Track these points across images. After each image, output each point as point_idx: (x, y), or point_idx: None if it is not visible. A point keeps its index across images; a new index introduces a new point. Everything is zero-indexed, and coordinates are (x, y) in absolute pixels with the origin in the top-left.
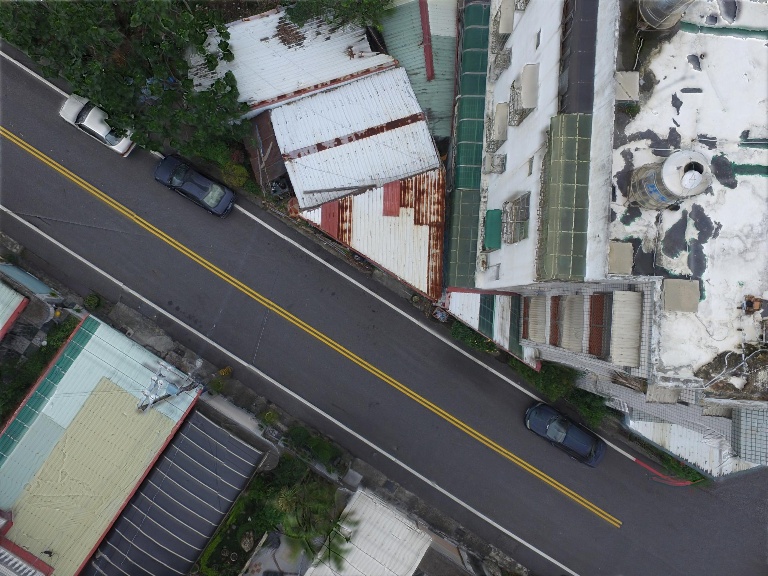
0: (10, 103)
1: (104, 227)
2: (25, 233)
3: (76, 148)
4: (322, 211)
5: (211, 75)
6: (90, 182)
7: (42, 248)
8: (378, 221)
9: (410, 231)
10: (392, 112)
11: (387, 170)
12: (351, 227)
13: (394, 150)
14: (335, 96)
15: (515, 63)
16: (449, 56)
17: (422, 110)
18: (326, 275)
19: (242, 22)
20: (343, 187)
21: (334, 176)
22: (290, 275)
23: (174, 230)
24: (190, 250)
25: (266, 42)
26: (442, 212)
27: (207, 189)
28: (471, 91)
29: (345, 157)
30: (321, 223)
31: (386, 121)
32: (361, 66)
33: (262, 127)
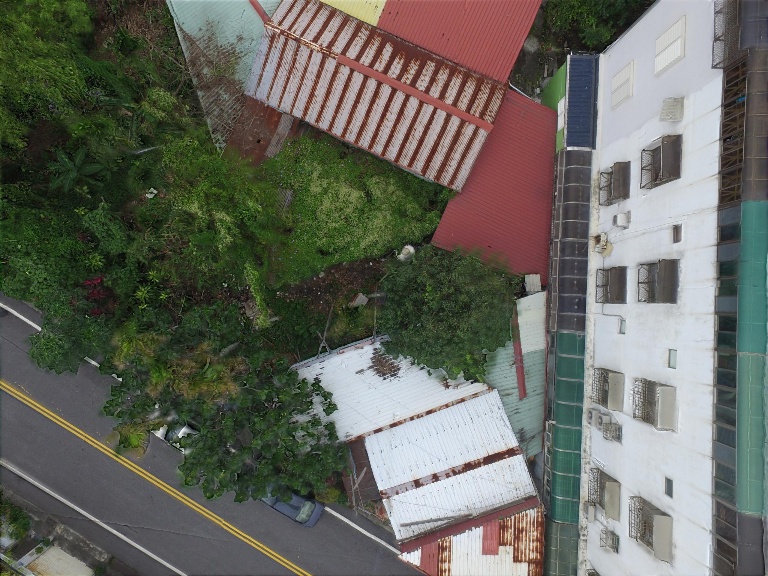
0: (96, 410)
1: (192, 533)
2: (113, 542)
3: (163, 454)
4: (422, 552)
5: (307, 411)
6: (177, 488)
7: (130, 556)
8: (477, 560)
9: (509, 568)
10: (488, 444)
11: (483, 500)
12: (450, 566)
13: (491, 482)
14: (429, 422)
15: (628, 453)
16: (539, 369)
17: (516, 434)
18: (413, 573)
19: (337, 355)
20: (439, 518)
21: (431, 508)
22: (378, 575)
23: (262, 535)
24: (278, 555)
25: (361, 374)
26: (541, 549)
27: (299, 508)
28: (567, 422)
29: (442, 491)
30: (421, 564)
31: (483, 456)
32: (456, 395)
33: (355, 451)
